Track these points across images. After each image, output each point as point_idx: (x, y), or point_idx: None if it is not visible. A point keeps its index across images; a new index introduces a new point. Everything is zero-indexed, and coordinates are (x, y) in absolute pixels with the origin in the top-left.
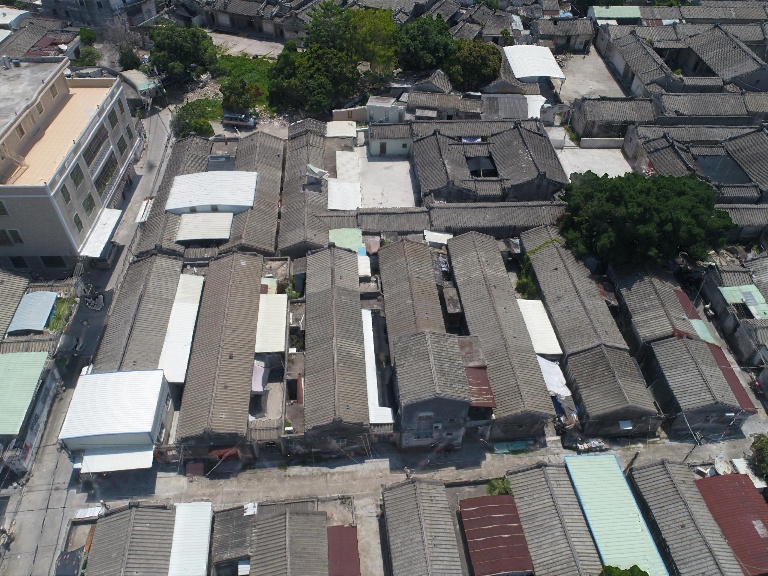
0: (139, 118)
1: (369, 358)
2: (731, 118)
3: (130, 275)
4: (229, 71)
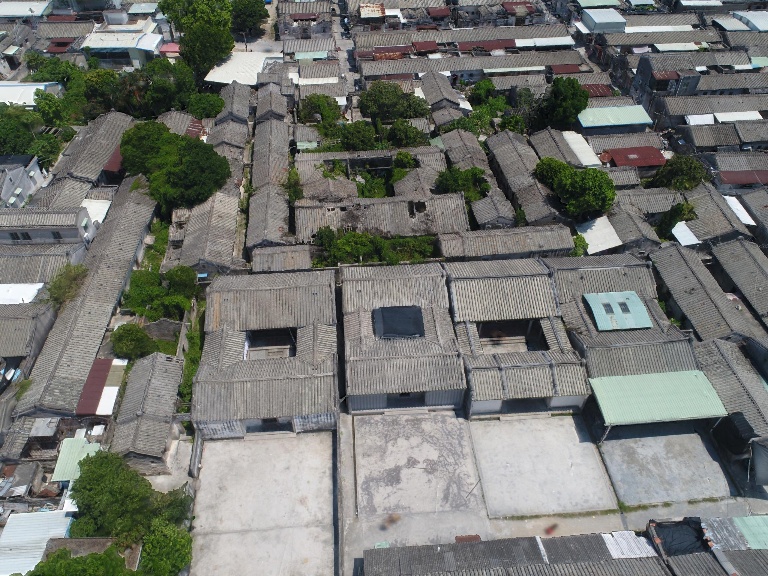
0: None
1: None
2: None
3: None
4: None
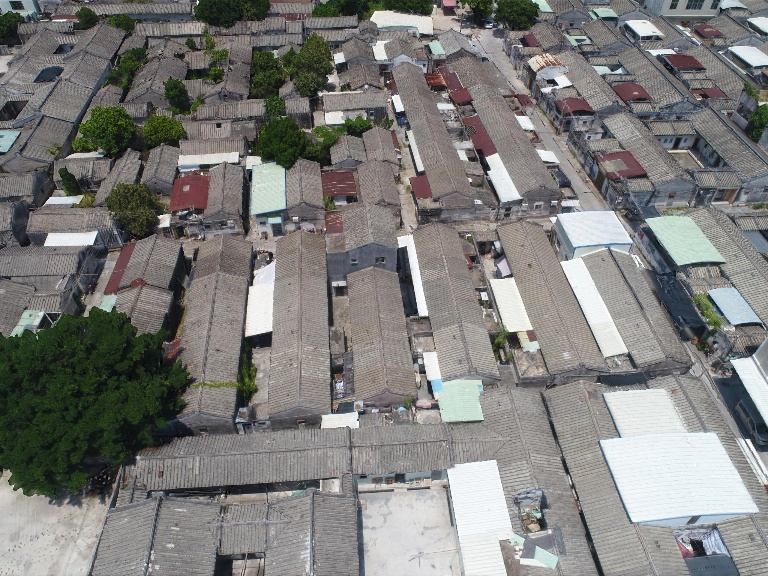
0: None
1: (417, 276)
2: None
3: (679, 345)
4: None
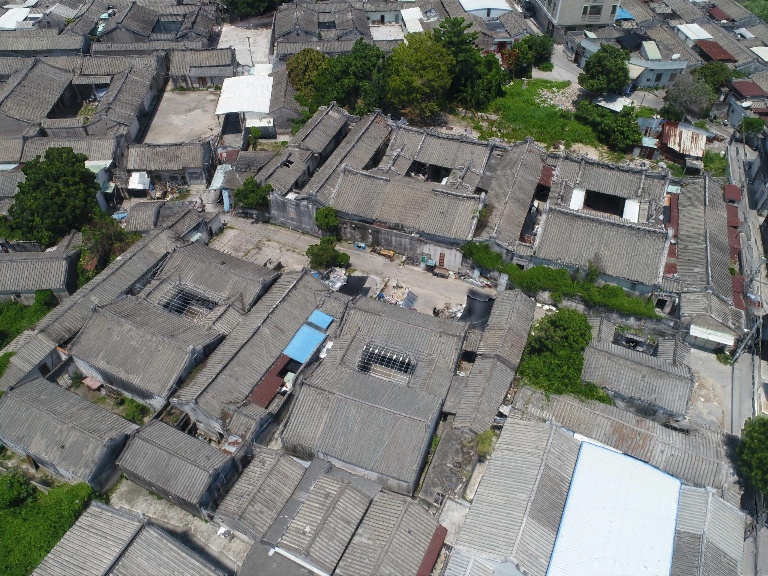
0: None
1: None
2: (115, 51)
3: None
4: (563, 114)
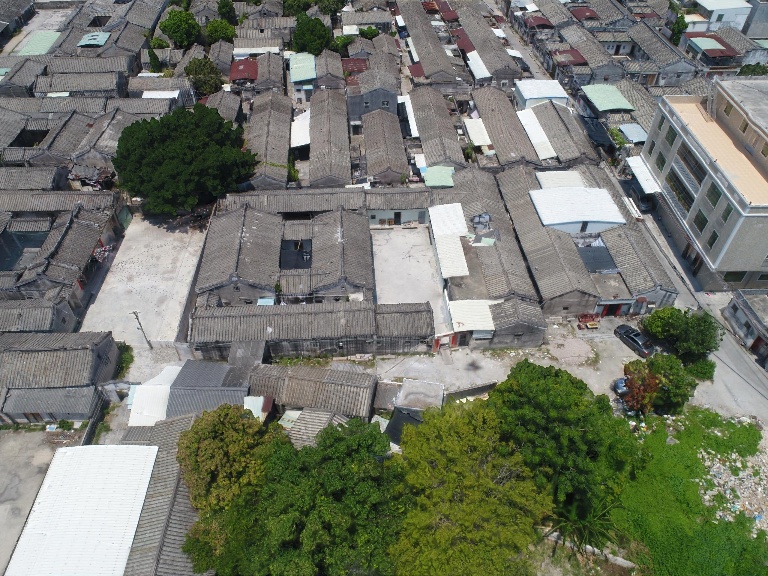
0: (766, 330)
1: (412, 117)
2: None
3: (592, 152)
4: None
